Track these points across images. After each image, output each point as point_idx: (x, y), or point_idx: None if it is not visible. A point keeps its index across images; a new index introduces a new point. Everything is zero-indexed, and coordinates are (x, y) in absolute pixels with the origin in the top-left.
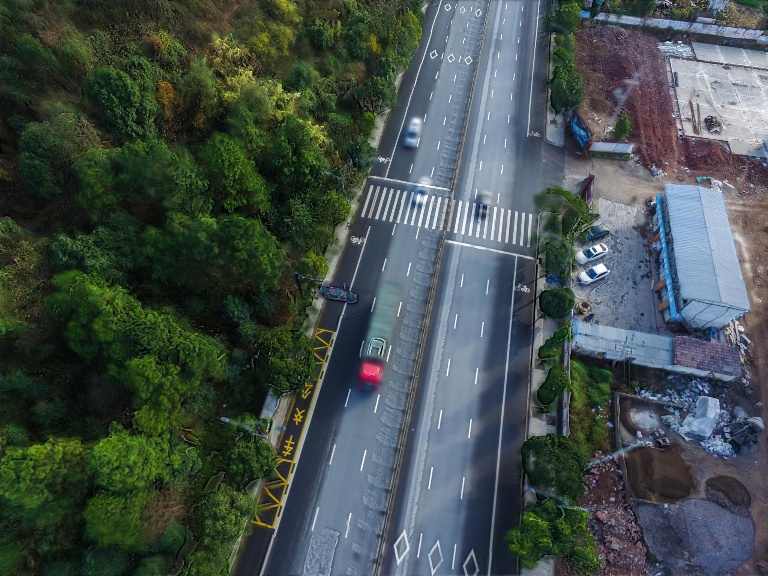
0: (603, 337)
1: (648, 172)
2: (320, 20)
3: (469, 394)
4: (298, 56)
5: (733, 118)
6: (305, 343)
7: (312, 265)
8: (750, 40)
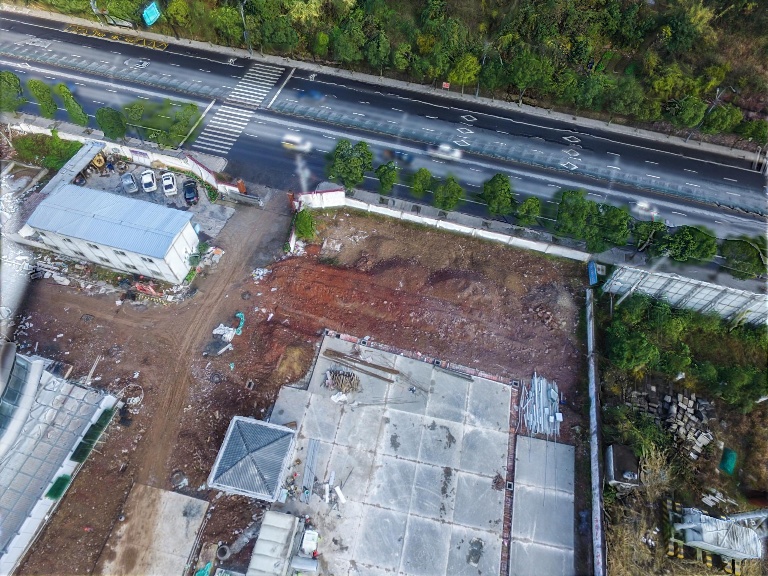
0: (82, 159)
1: (262, 264)
2: (442, 4)
3: (88, 97)
4: (404, 5)
5: (357, 424)
6: (125, 3)
7: (173, 0)
8: (593, 570)
